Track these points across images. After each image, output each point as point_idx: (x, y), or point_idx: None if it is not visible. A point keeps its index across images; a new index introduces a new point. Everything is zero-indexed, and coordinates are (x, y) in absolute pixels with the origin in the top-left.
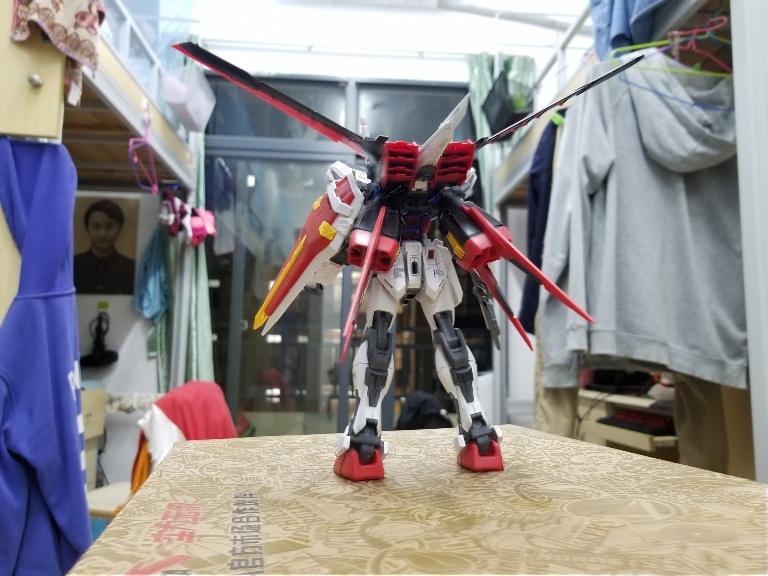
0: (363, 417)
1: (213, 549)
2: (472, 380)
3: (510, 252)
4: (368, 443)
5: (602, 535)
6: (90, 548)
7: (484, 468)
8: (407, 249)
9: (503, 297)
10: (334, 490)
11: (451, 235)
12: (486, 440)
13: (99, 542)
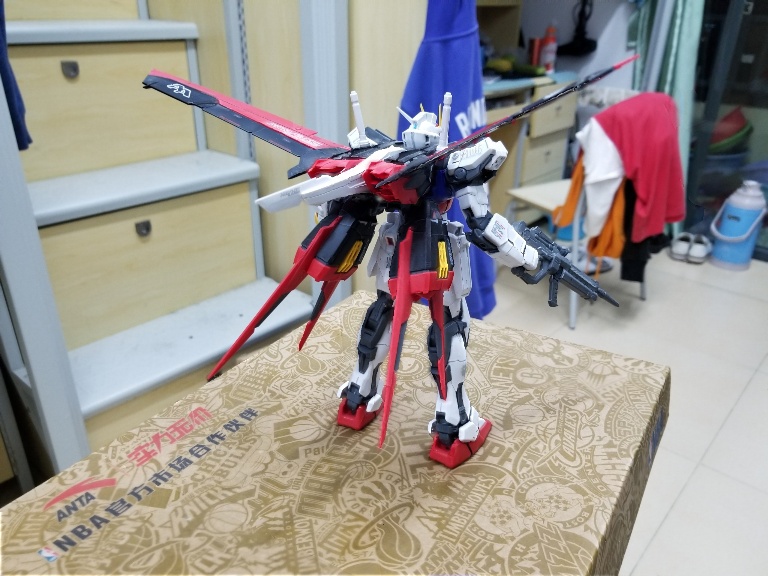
0: (350, 380)
1: (134, 480)
2: (448, 381)
3: None
4: (352, 401)
5: None
6: (99, 449)
7: (436, 460)
8: None
9: (435, 337)
10: (303, 433)
11: None
12: (446, 438)
13: (109, 445)
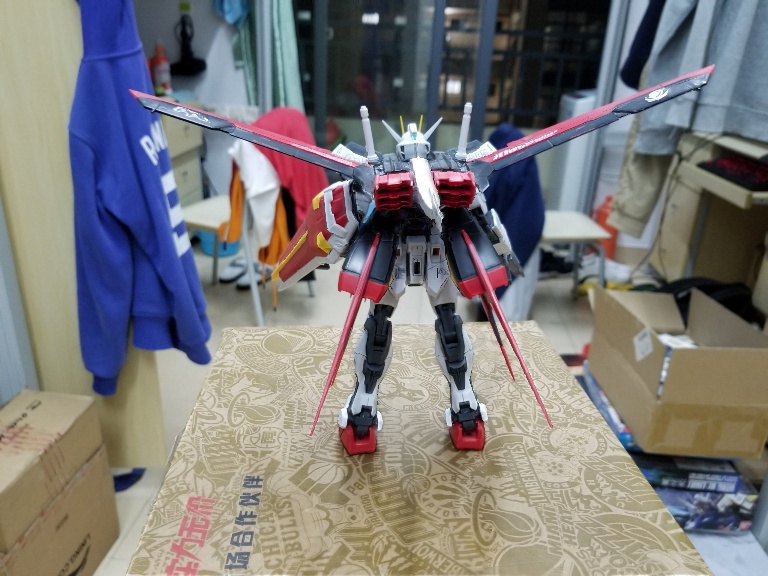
0: (359, 404)
1: None
2: (465, 371)
3: (497, 313)
4: (363, 425)
5: None
6: None
7: (465, 448)
8: (410, 250)
9: (495, 327)
10: (327, 476)
11: None
12: (471, 424)
13: None
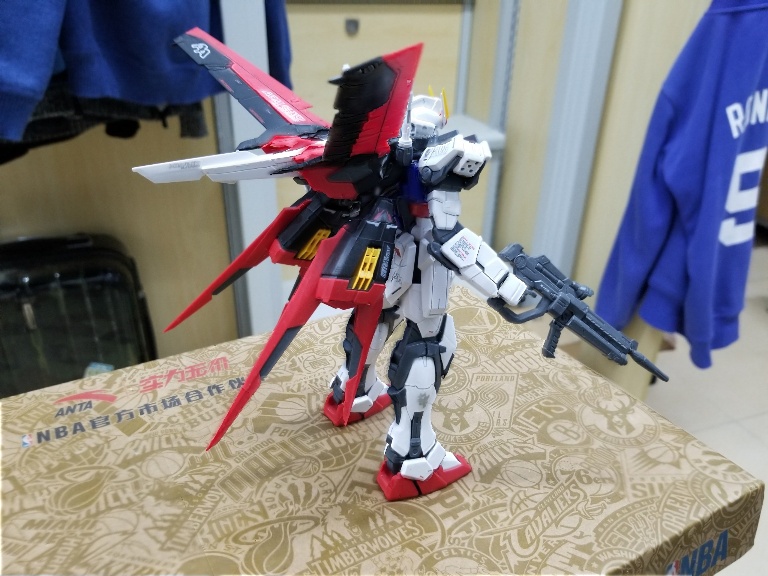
0: None
1: (128, 403)
2: (402, 405)
3: None
4: (336, 394)
5: (114, 575)
6: None
7: None
8: None
9: None
10: (288, 410)
11: None
12: (390, 466)
13: (135, 366)
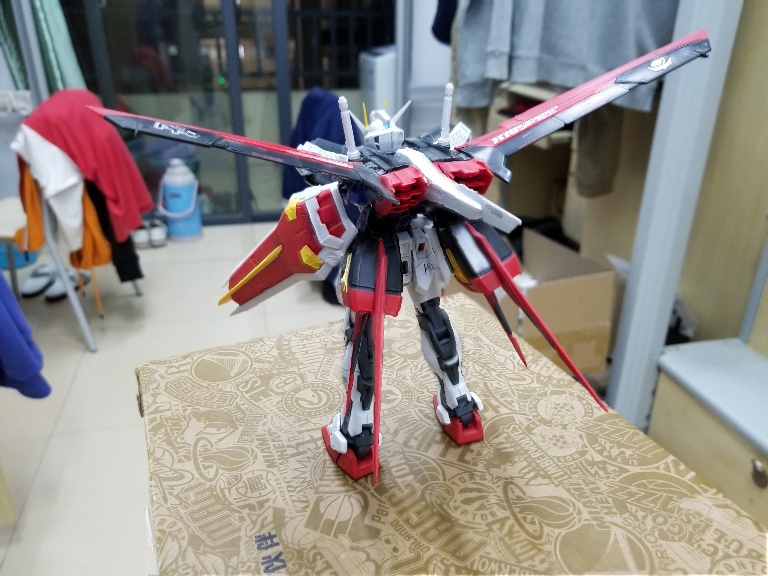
0: (358, 424)
1: None
2: (458, 365)
3: (524, 305)
4: (364, 445)
5: None
6: None
7: (467, 442)
8: None
9: (503, 317)
10: (343, 510)
11: (454, 258)
12: (469, 417)
13: None
